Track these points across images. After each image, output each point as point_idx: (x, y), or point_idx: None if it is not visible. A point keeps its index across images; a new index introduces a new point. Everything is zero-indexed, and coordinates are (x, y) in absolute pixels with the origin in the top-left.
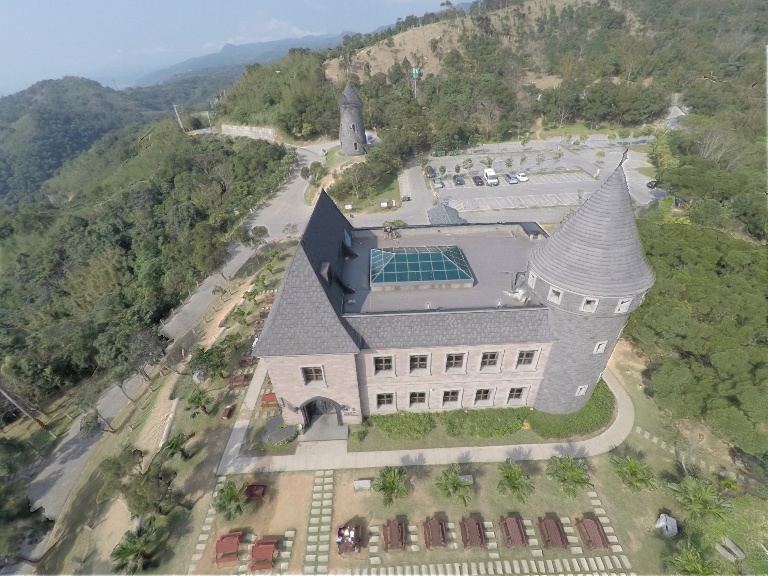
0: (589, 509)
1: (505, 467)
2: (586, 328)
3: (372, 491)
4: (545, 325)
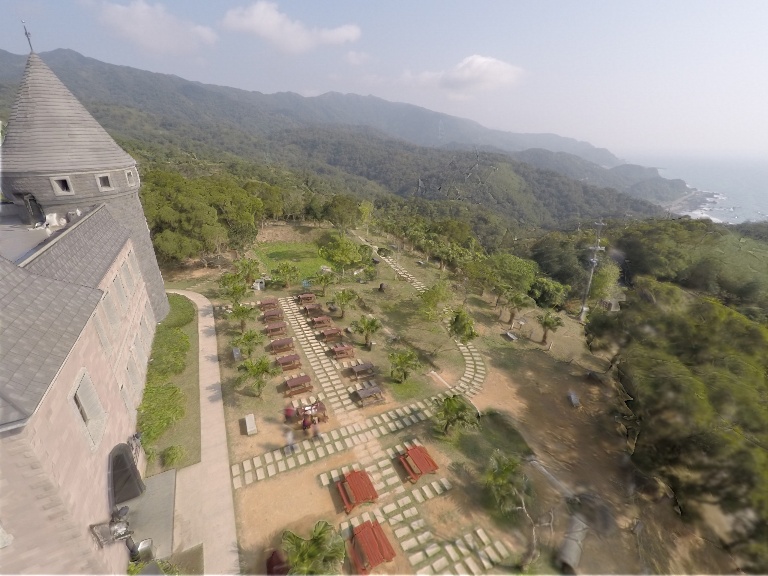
0: (252, 307)
1: (233, 313)
2: (136, 207)
3: (256, 417)
4: (115, 222)
